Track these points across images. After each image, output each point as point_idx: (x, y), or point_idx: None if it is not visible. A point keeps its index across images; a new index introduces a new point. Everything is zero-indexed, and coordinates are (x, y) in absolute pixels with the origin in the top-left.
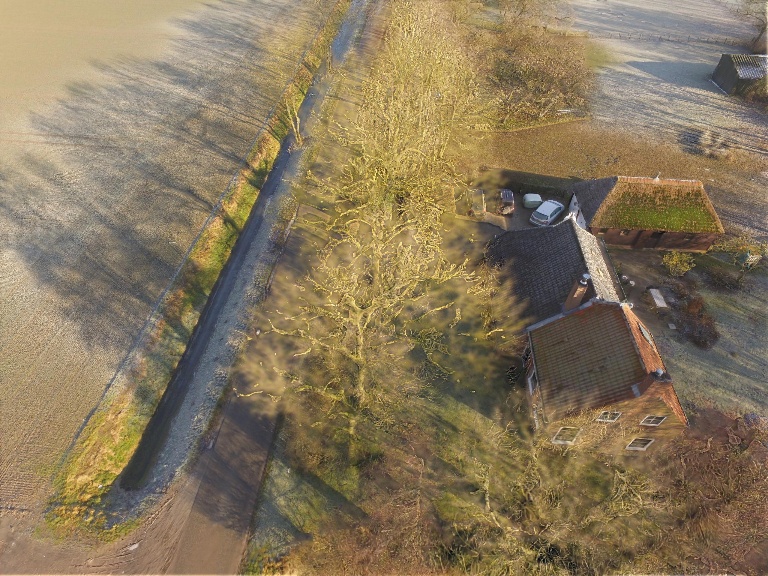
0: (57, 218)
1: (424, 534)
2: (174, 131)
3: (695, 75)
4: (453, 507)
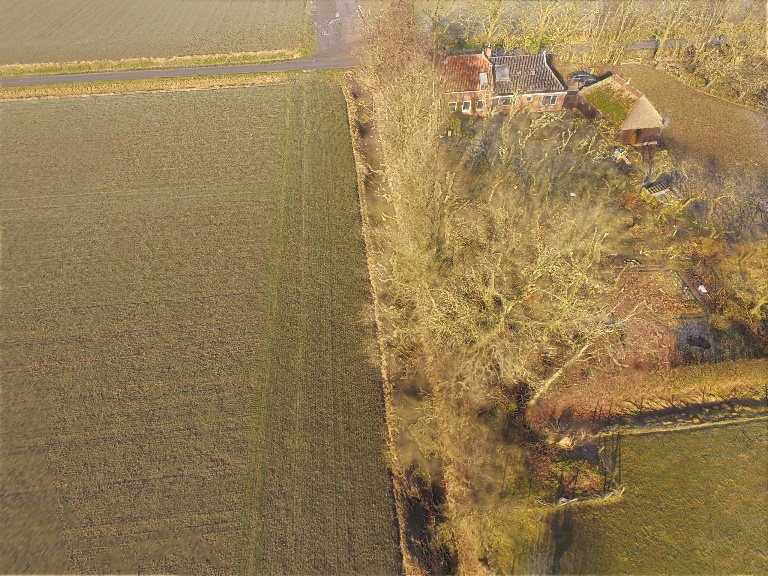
0: (475, 15)
1: None
2: None
3: None
4: None
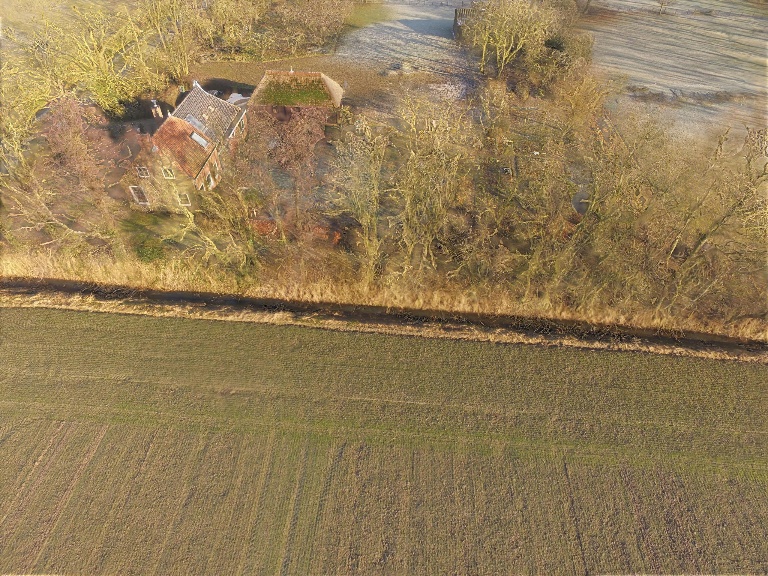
0: None
1: (36, 243)
2: (1, 63)
3: (444, 28)
4: (62, 234)
